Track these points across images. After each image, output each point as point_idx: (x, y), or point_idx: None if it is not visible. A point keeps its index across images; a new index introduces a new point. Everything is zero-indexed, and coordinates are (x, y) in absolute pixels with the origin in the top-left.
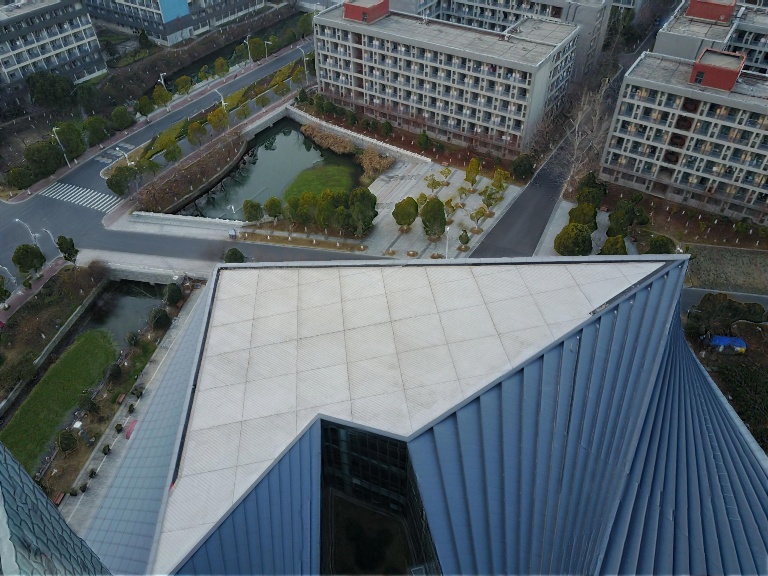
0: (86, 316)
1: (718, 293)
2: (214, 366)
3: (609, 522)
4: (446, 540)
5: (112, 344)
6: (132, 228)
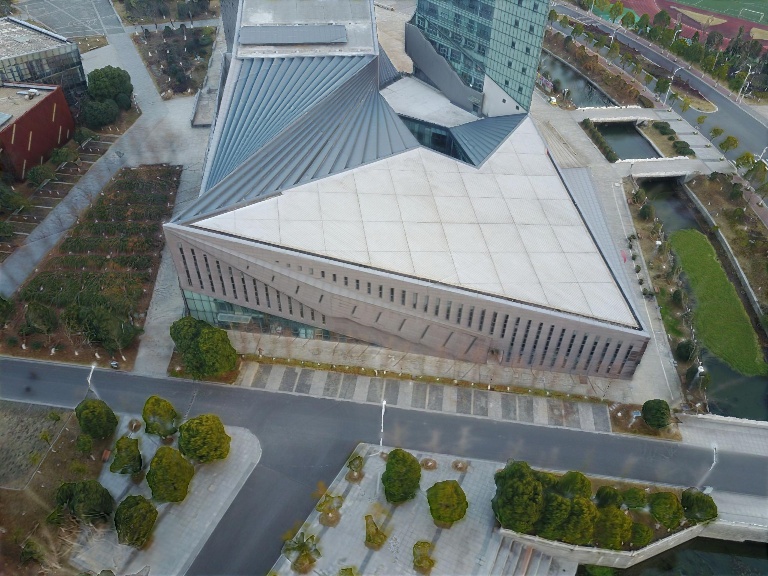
0: None
1: (102, 313)
2: (570, 216)
3: (325, 99)
4: (398, 124)
5: (723, 359)
6: None
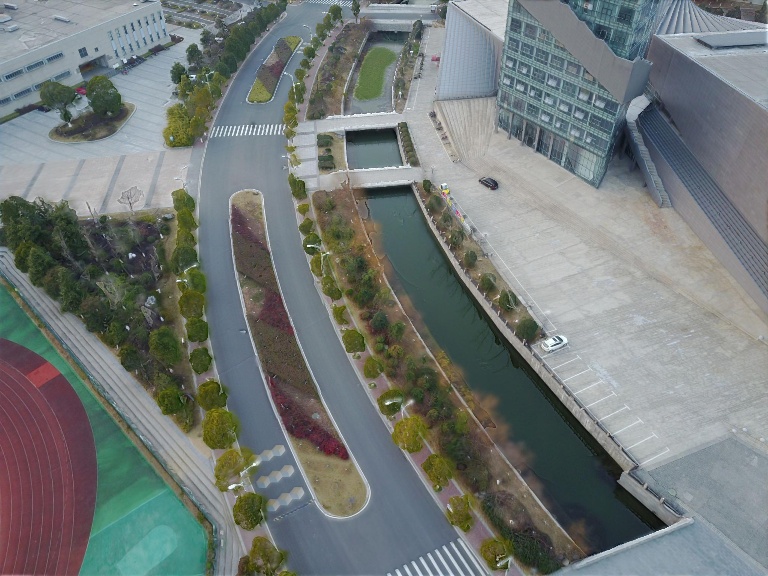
0: (368, 43)
1: (701, 4)
2: None
3: None
4: None
5: (390, 50)
6: (372, 11)
